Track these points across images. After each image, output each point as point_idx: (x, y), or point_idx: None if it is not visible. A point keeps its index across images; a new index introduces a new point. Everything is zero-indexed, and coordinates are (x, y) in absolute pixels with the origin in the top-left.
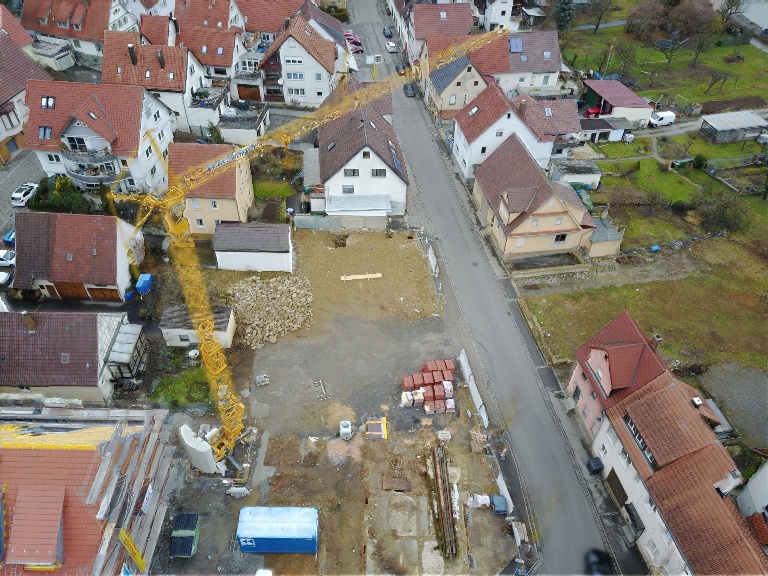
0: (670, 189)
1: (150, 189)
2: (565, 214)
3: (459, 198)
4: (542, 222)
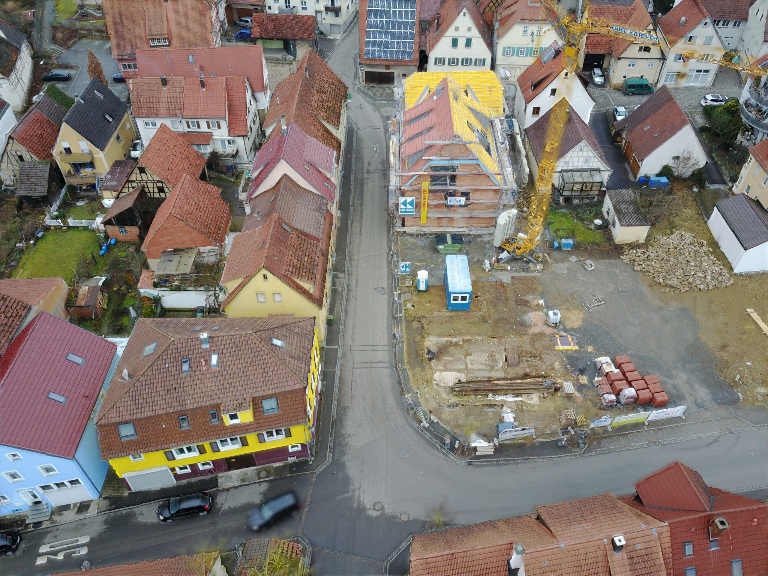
0: None
1: None
2: None
3: None
4: None
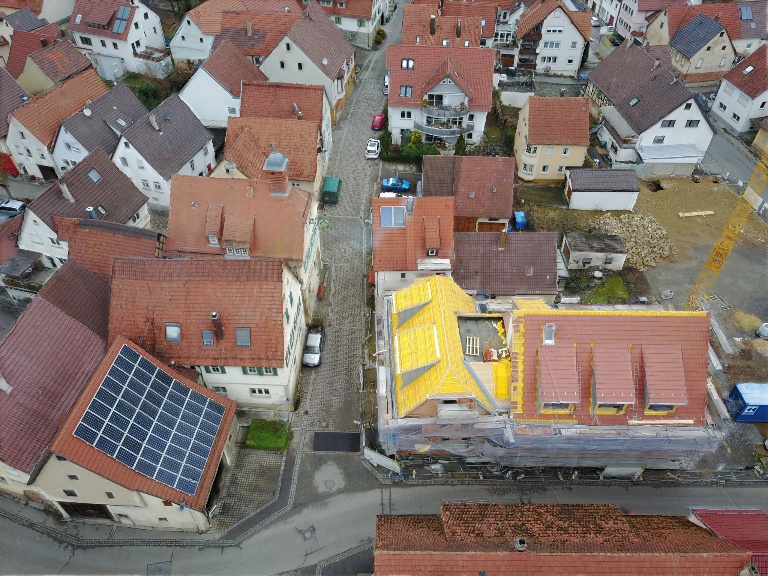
0: None
1: None
2: None
3: (739, 149)
4: None
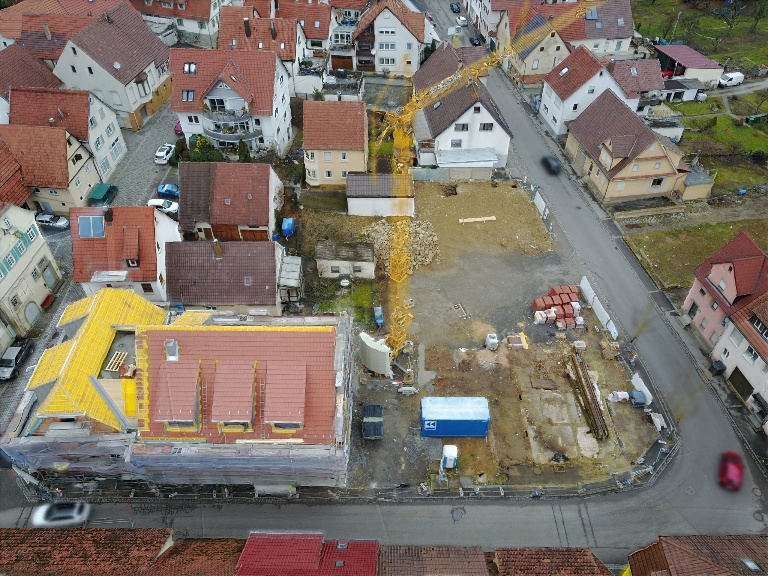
0: (747, 142)
1: (276, 147)
2: (664, 158)
3: (552, 152)
4: (642, 167)
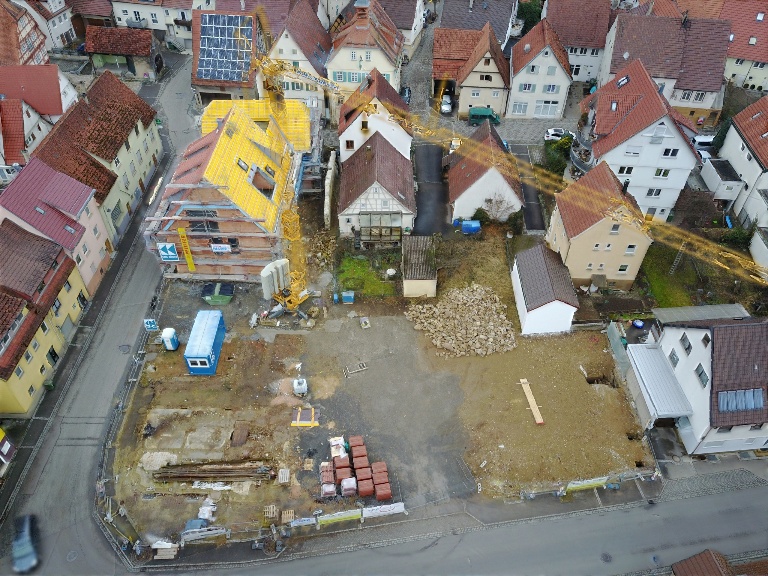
0: None
1: None
2: None
3: None
4: None
